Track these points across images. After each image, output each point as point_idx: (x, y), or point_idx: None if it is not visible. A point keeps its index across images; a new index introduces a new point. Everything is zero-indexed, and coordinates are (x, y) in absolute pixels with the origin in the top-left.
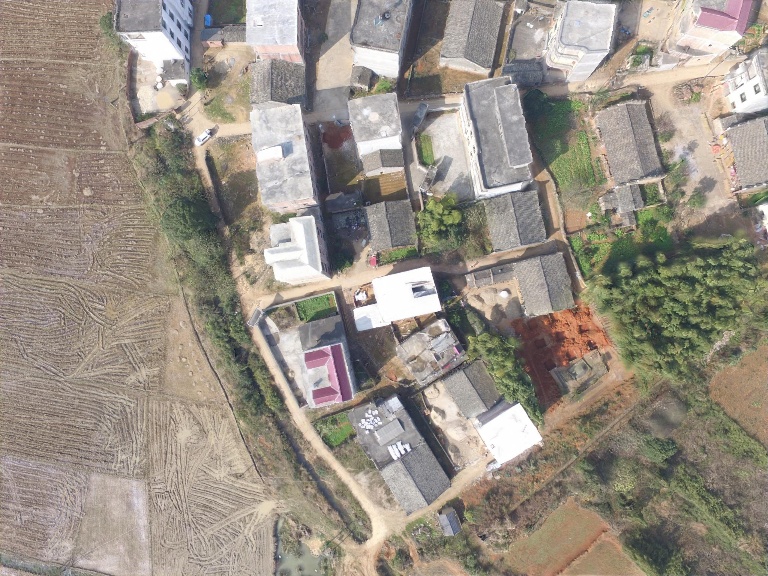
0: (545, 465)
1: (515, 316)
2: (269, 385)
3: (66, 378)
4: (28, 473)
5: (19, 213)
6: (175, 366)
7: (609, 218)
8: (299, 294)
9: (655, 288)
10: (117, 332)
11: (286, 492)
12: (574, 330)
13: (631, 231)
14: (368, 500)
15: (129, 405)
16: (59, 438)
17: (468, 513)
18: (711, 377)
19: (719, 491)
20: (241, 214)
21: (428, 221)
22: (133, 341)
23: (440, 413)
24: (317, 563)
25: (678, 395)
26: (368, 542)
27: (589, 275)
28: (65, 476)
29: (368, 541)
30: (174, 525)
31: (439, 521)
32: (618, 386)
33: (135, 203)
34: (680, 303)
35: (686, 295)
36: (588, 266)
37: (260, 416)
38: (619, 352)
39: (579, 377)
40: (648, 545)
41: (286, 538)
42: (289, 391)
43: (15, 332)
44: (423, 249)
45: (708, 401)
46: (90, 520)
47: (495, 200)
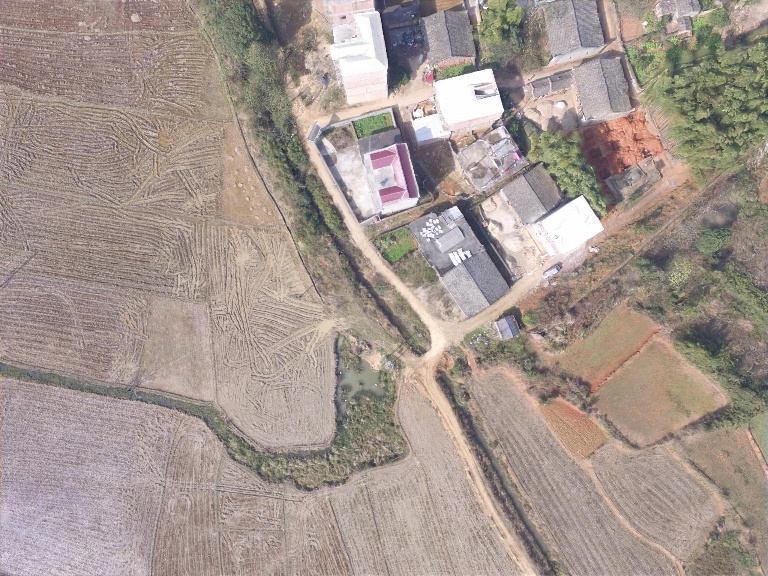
0: (601, 266)
1: (571, 127)
2: (328, 204)
3: (122, 205)
4: (88, 299)
5: (66, 40)
6: (232, 192)
7: (665, 26)
8: (355, 114)
9: (716, 76)
10: (172, 159)
11: (346, 309)
12: (629, 138)
13: (687, 37)
14: (427, 313)
15: (187, 231)
16: (118, 264)
17: (526, 316)
18: (761, 178)
19: (766, 287)
20: (295, 36)
21: (491, 21)
22: (188, 168)
23: (497, 225)
24: (377, 378)
25: (729, 198)
26: (427, 354)
27: (645, 81)
28: (126, 301)
29: (427, 353)
30: (236, 345)
31: (498, 326)
32: (671, 192)
33: (185, 29)
34: (741, 88)
35: (747, 79)
36: (644, 74)
37: (319, 236)
38: (675, 153)
39: (634, 183)
40: (698, 339)
41: (346, 355)
42: (347, 210)
43: (68, 160)
44: (481, 60)
45: (758, 202)
46: (153, 343)
47: (555, 4)
